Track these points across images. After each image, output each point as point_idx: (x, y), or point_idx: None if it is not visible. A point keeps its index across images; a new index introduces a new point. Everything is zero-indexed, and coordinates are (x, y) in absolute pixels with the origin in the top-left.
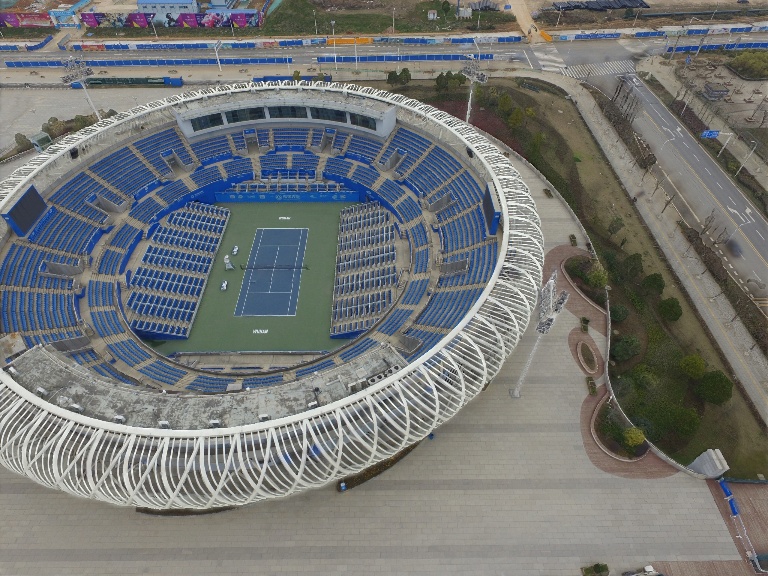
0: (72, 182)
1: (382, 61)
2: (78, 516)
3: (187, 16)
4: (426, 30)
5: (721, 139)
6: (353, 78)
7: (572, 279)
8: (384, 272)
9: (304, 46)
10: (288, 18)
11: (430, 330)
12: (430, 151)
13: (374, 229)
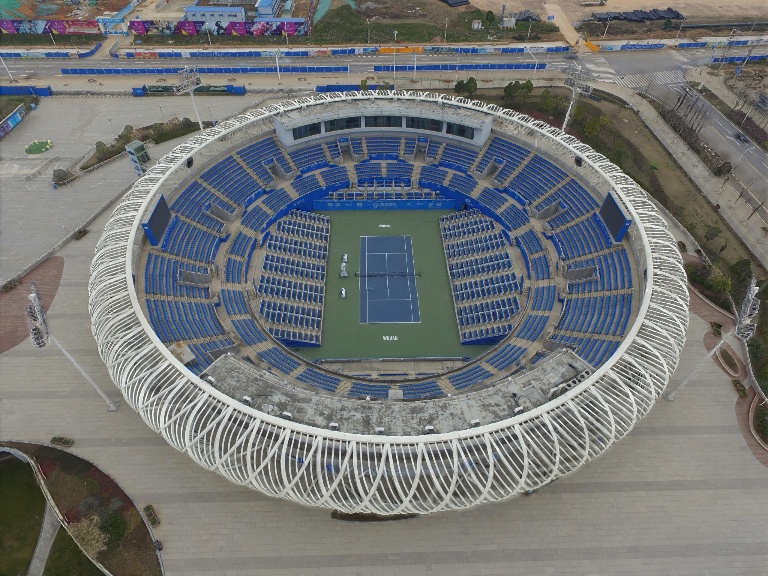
0: (187, 191)
1: (437, 70)
2: (276, 523)
3: (236, 24)
4: (473, 40)
5: None
6: (413, 87)
7: (692, 285)
8: (504, 279)
9: (356, 55)
10: (335, 27)
11: (578, 336)
12: (530, 160)
13: (481, 236)
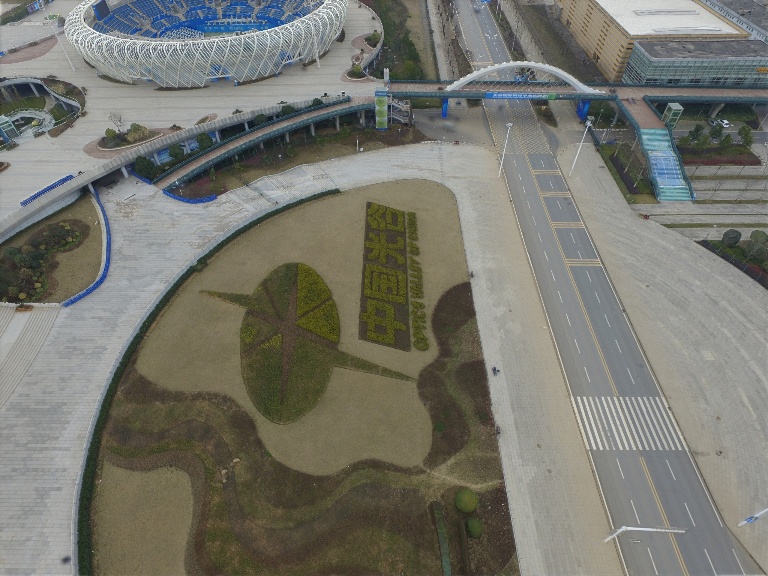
0: (121, 7)
1: None
2: (132, 91)
3: None
4: None
5: (505, 9)
6: None
7: (366, 41)
8: None
9: None
10: None
11: None
12: None
13: None
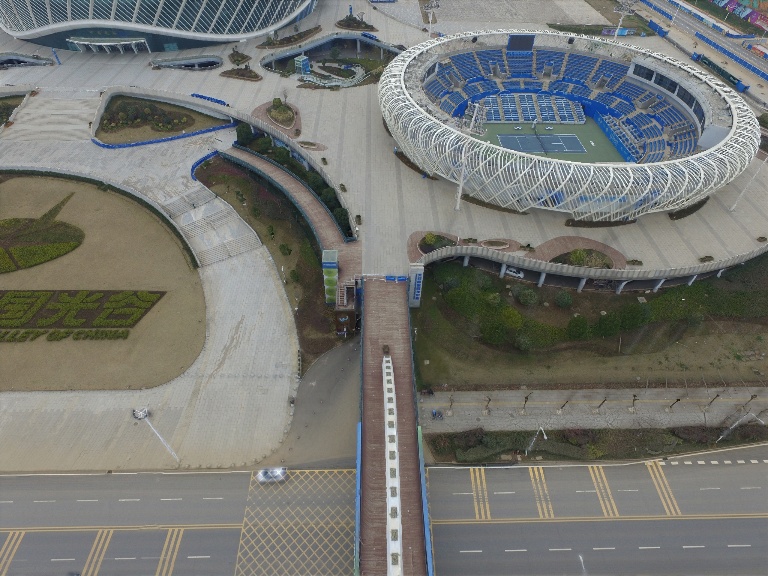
0: (555, 53)
1: None
2: None
3: None
4: None
5: None
6: None
7: None
8: None
9: None
10: None
11: None
12: None
13: None
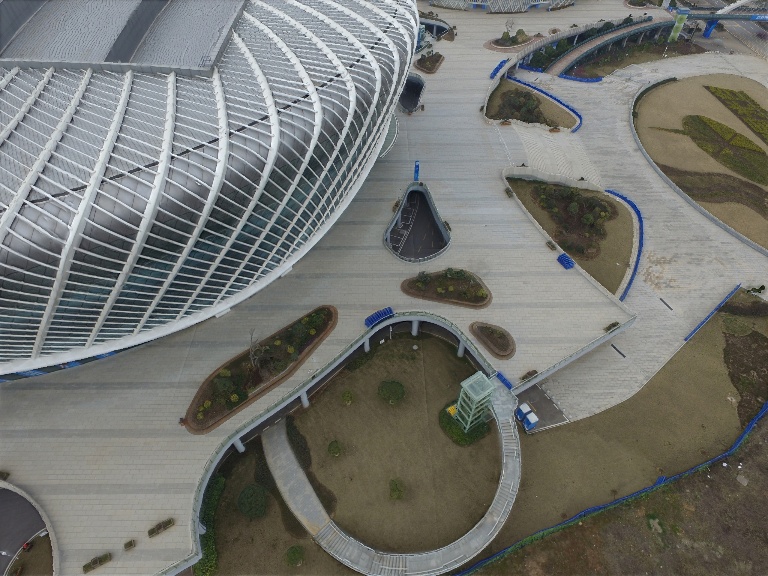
0: None
1: None
2: (470, 14)
3: None
4: None
5: None
6: None
7: None
8: None
9: None
10: None
11: None
12: None
13: None
